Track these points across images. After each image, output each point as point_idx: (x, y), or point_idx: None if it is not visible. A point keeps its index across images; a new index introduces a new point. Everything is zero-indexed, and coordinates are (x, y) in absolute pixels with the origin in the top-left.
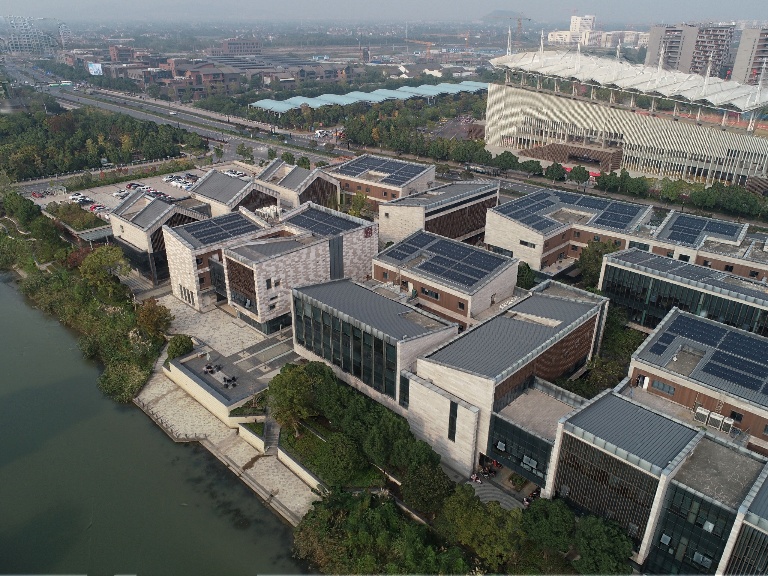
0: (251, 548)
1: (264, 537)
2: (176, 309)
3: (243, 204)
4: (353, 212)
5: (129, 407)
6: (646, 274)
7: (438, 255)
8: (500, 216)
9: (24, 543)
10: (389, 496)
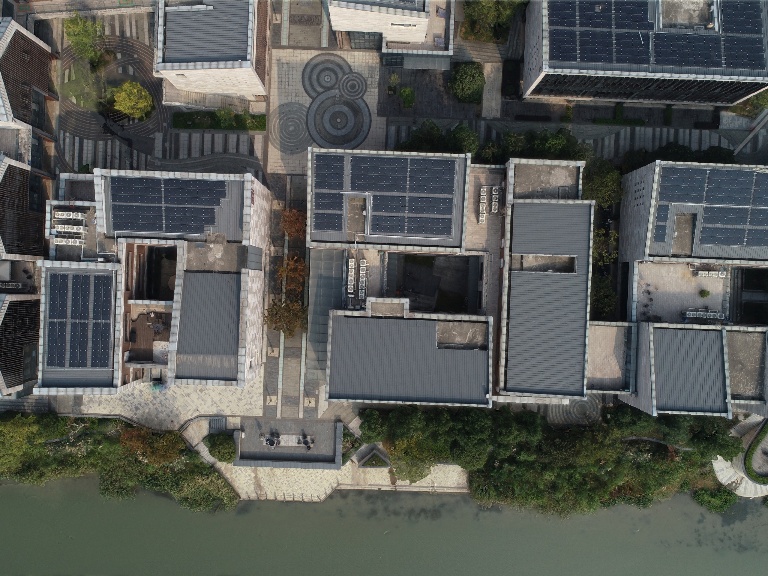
0: (456, 522)
1: (456, 511)
2: (126, 395)
3: (3, 230)
4: (122, 92)
5: (245, 505)
6: (595, 75)
7: (374, 194)
8: (354, 10)
9: None
10: (513, 444)
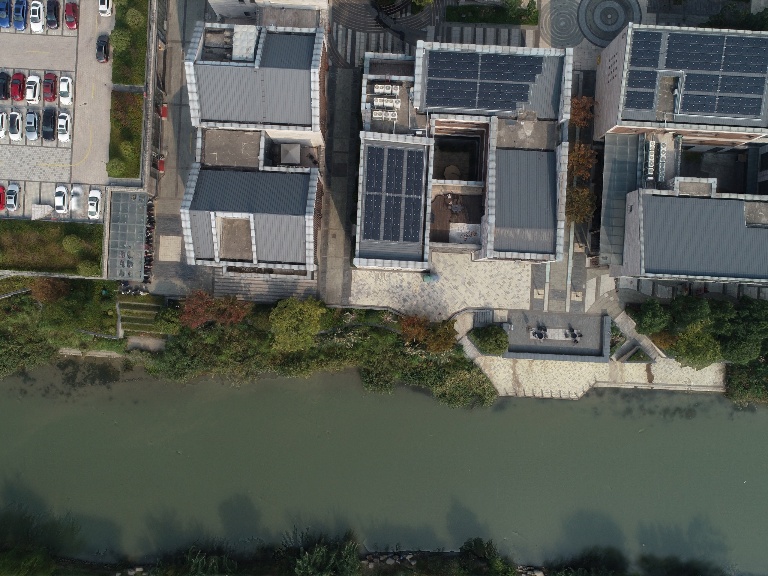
0: (710, 422)
1: (710, 411)
2: (395, 286)
3: None
4: None
5: (502, 402)
6: None
7: (688, 72)
8: None
9: (594, 524)
10: None
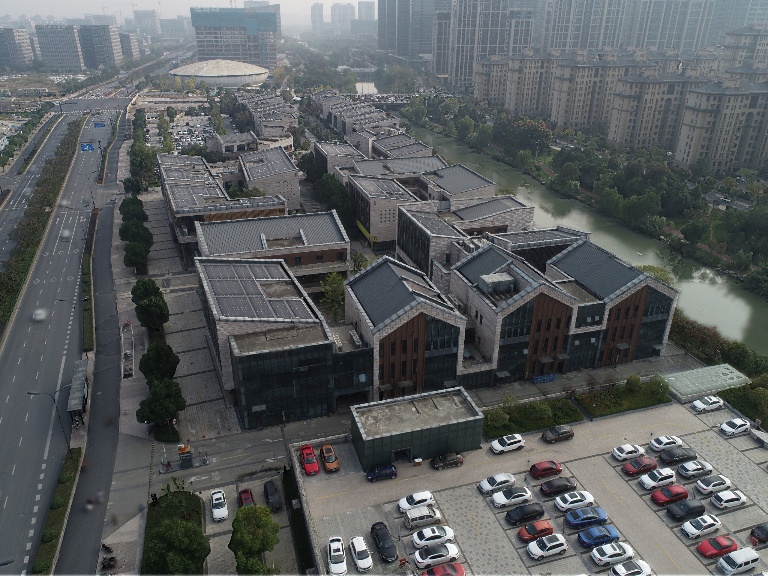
0: None
1: None
2: None
3: None
4: None
5: None
6: None
7: None
8: None
9: None
10: None
